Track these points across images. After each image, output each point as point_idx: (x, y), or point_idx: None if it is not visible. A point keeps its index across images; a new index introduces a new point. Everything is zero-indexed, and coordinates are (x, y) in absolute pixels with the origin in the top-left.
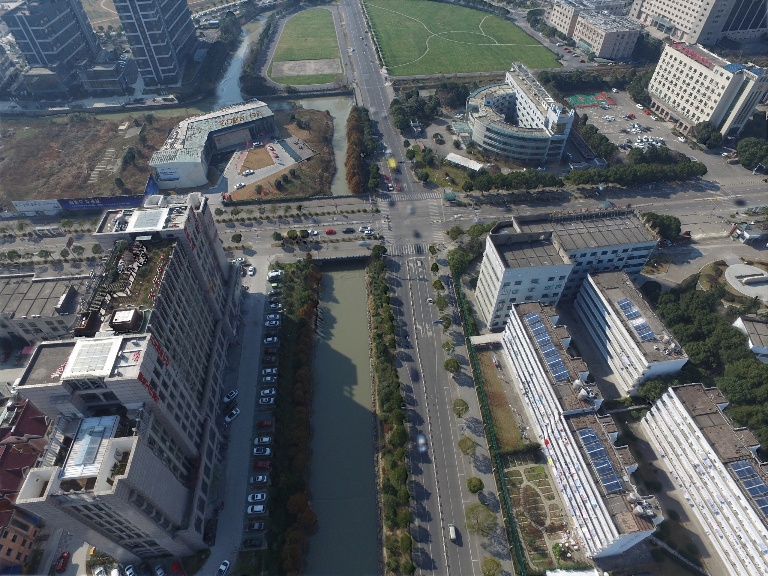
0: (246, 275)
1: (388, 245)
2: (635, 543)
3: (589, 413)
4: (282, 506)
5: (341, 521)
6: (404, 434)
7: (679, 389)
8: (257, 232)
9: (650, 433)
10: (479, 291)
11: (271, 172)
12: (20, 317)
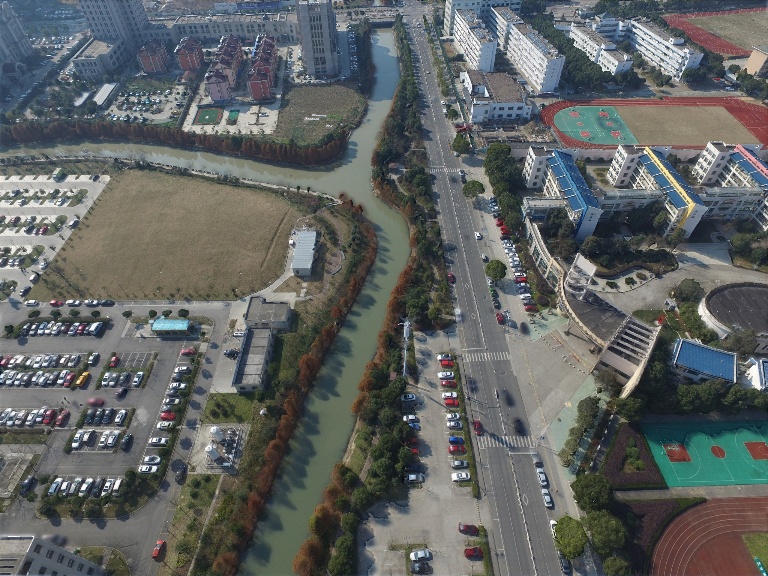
0: (336, 27)
1: (403, 19)
2: (490, 60)
3: (479, 28)
4: (364, 68)
5: (386, 77)
6: (410, 51)
7: (515, 24)
8: (337, 16)
9: (508, 53)
10: (445, 24)
11: (339, 0)
12: (248, 21)
